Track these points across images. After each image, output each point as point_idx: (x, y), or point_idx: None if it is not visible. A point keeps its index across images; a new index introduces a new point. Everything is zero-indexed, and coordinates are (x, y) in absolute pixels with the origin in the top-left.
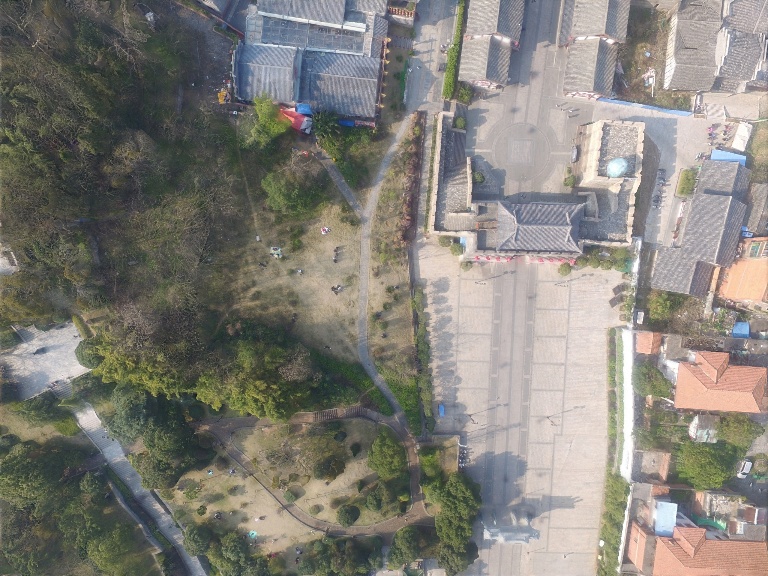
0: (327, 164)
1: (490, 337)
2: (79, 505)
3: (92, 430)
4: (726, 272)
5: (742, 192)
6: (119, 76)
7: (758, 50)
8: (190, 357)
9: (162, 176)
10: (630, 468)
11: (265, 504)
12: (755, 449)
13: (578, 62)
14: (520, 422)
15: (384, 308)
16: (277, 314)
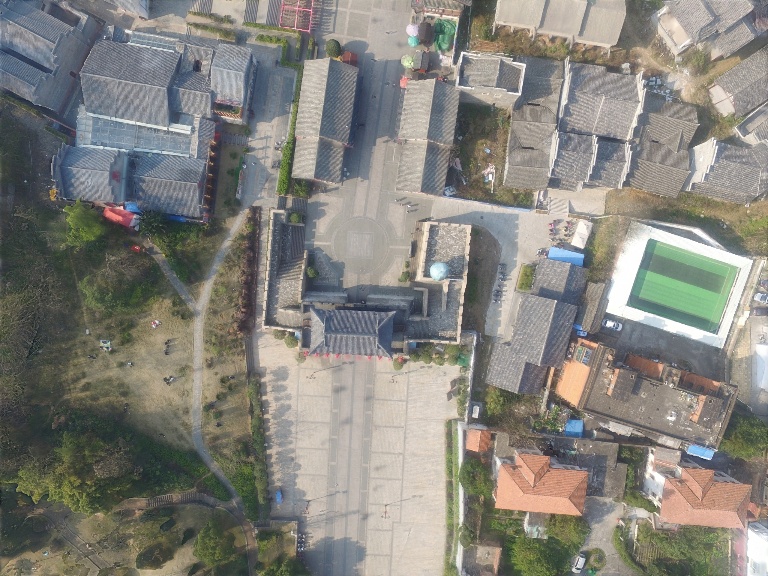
0: (159, 259)
1: (329, 425)
2: None
3: None
4: (563, 369)
5: (578, 291)
6: None
7: (589, 154)
8: (2, 455)
9: None
10: (460, 561)
11: None
12: (591, 544)
13: (409, 162)
14: (359, 509)
15: (217, 398)
16: (108, 404)
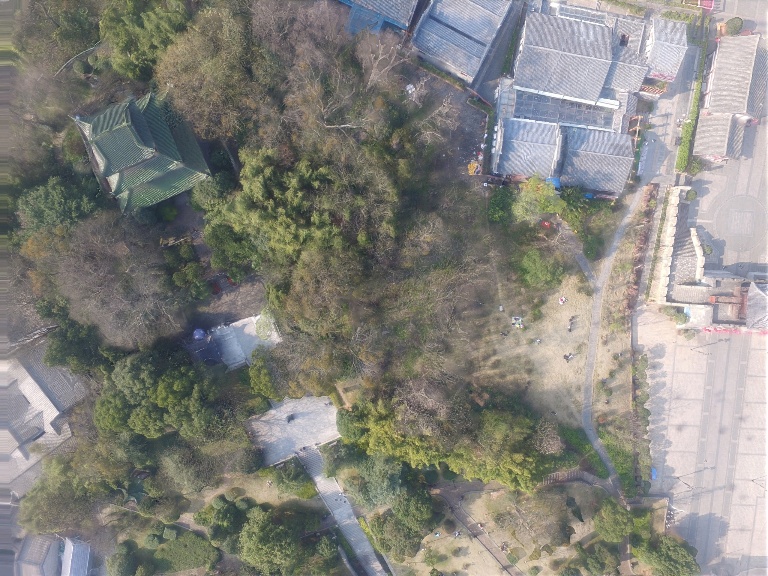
0: (566, 235)
1: (701, 402)
2: (306, 565)
3: (327, 493)
4: None
5: None
6: (414, 159)
7: None
8: None
9: (441, 255)
10: None
11: (486, 565)
12: None
13: None
14: (725, 485)
15: (610, 375)
16: (513, 382)
